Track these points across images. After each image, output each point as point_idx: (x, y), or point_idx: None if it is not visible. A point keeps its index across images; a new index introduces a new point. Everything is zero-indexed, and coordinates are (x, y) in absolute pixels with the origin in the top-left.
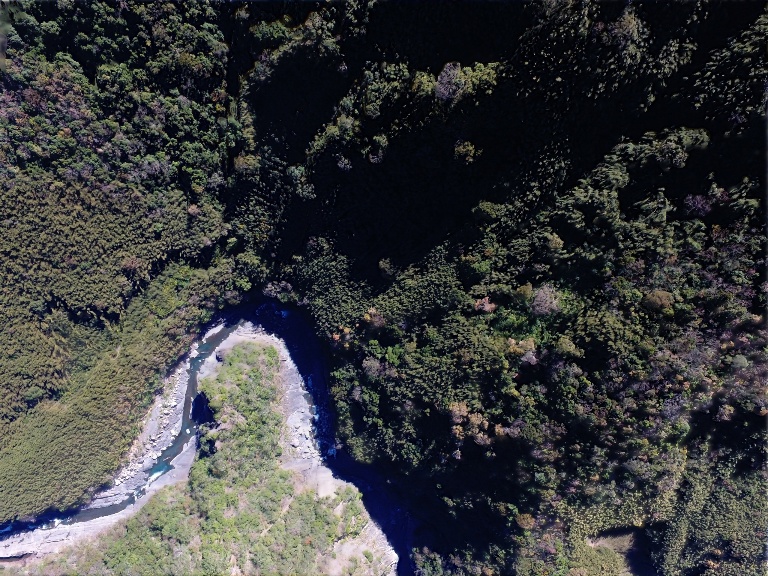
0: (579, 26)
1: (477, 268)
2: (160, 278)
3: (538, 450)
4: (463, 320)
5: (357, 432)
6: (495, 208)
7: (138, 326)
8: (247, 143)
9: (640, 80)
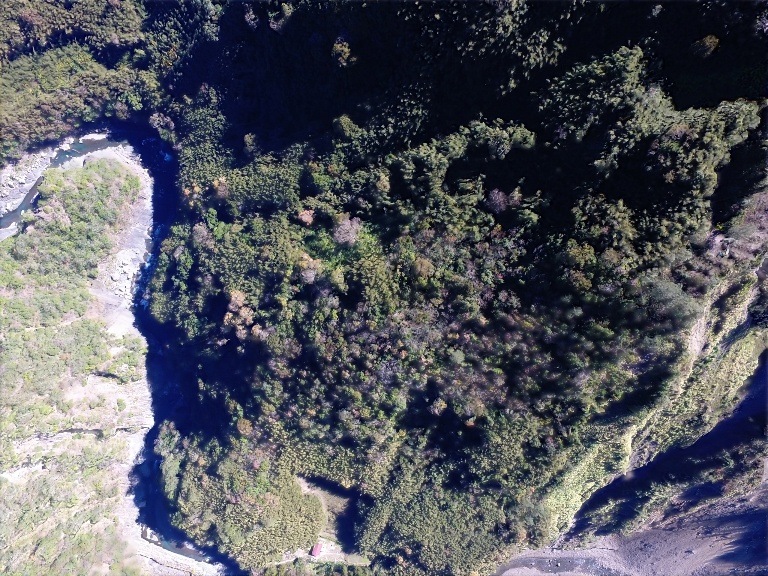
0: None
1: (315, 178)
2: (58, 51)
3: (274, 361)
4: (285, 223)
5: (165, 290)
6: (351, 127)
7: (16, 85)
8: None
9: (506, 57)
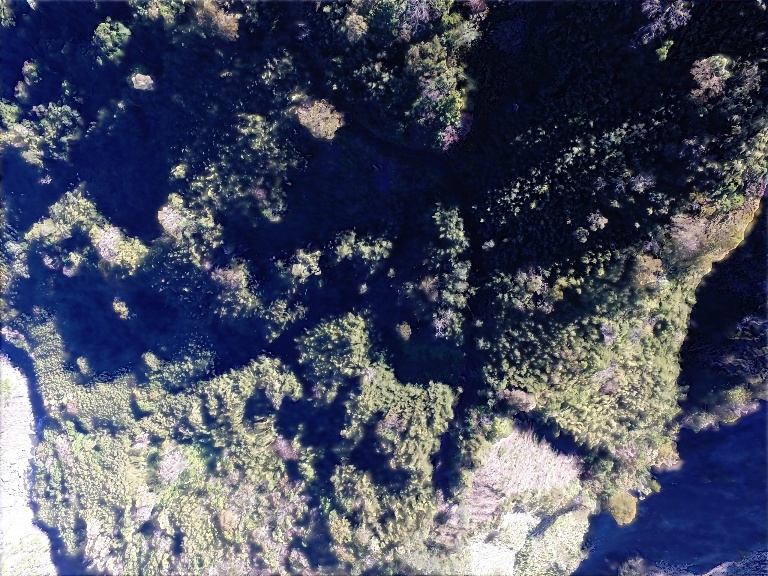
0: (189, 258)
1: (141, 406)
2: None
3: None
4: (127, 444)
5: (48, 494)
6: (157, 363)
7: None
8: None
9: None
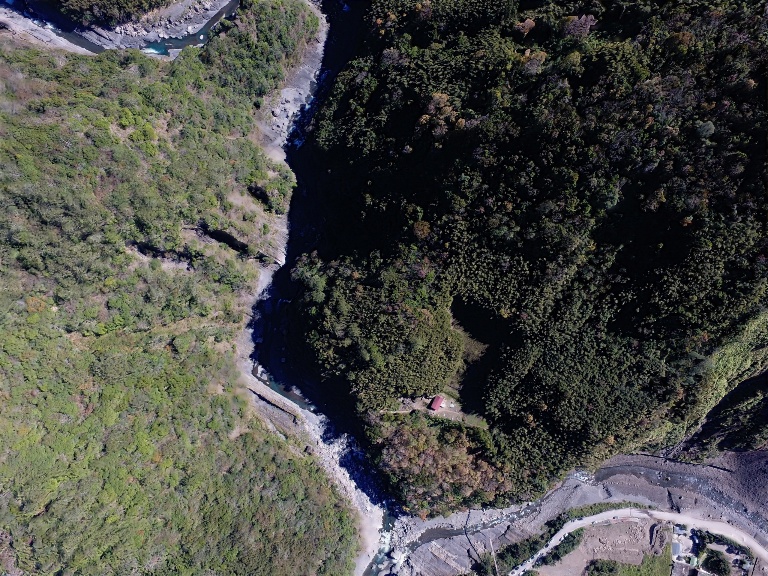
0: None
1: None
2: None
3: (481, 148)
4: None
5: (335, 118)
6: None
7: None
8: None
9: None
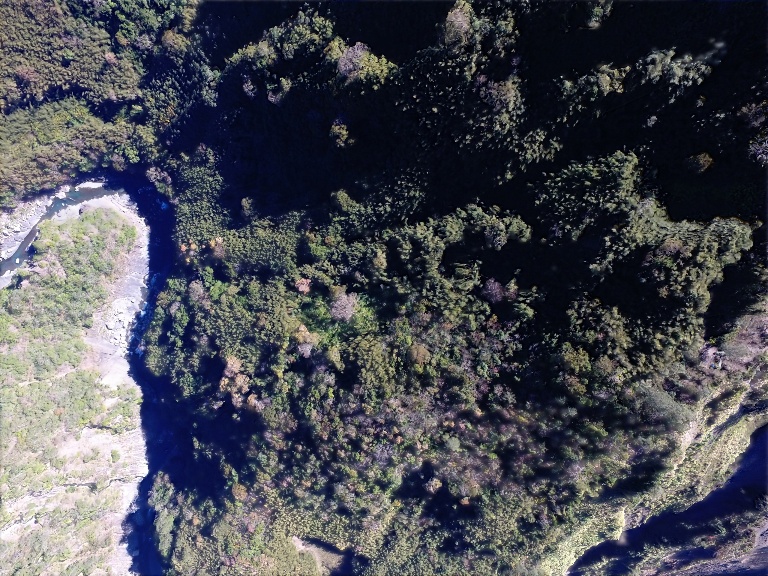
0: (465, 68)
1: (312, 249)
2: (55, 105)
3: (270, 433)
4: (282, 289)
5: (161, 343)
6: (349, 202)
7: (12, 137)
8: (182, 22)
9: (503, 152)
